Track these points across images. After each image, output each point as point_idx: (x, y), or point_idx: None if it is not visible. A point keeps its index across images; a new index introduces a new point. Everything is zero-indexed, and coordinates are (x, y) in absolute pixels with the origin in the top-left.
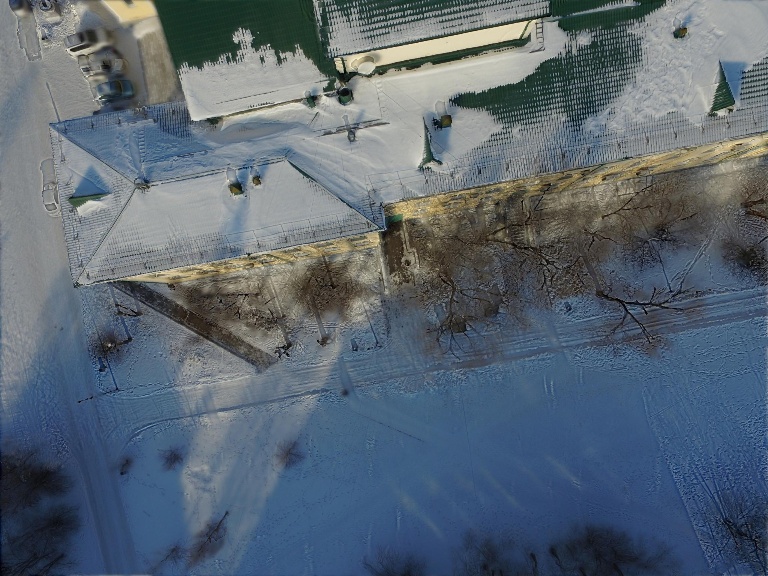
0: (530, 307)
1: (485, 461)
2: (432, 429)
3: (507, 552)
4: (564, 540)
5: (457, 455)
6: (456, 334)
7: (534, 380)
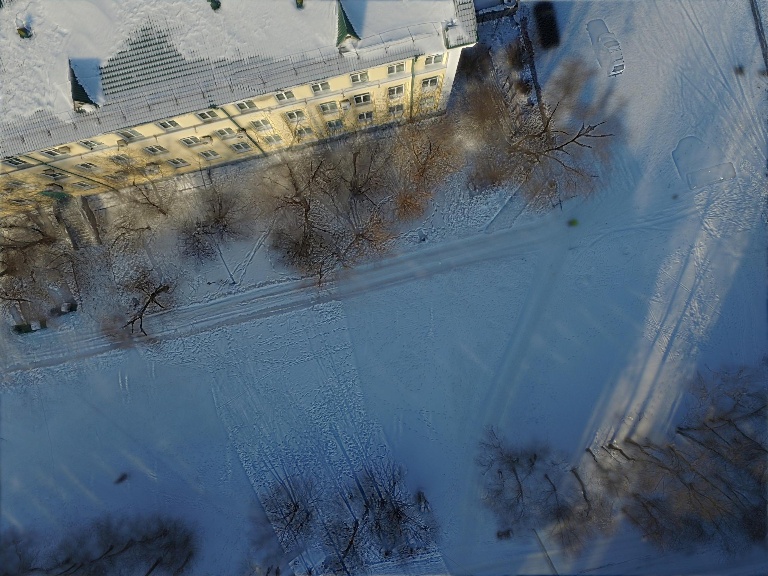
0: (103, 304)
1: (66, 457)
2: (14, 428)
3: (87, 545)
4: (141, 531)
5: (39, 452)
6: (33, 334)
7: (109, 376)
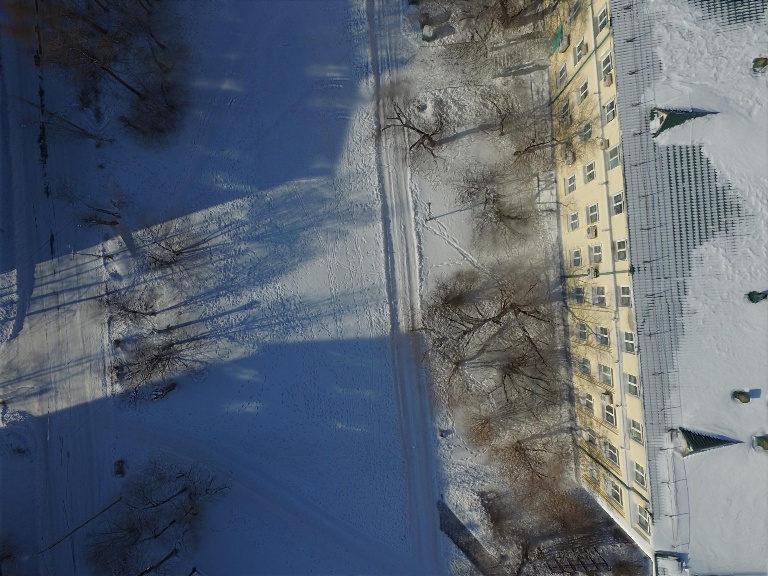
0: (425, 70)
1: (265, 8)
2: None
3: (169, 20)
4: (175, 81)
5: None
6: None
7: (346, 67)
